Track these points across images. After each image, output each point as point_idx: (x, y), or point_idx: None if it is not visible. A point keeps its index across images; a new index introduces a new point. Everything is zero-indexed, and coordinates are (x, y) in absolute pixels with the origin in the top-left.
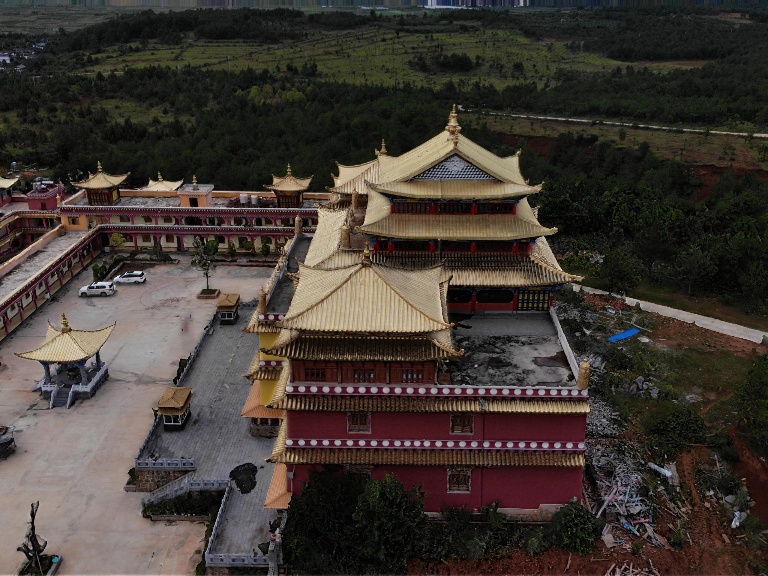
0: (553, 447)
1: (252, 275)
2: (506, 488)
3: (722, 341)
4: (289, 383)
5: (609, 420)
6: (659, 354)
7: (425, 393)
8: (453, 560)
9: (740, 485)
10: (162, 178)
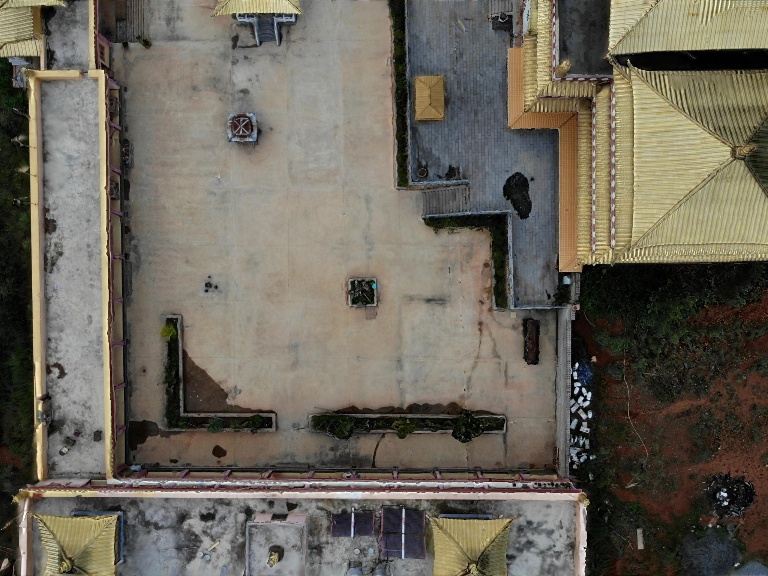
0: None
1: None
2: None
3: None
4: None
5: None
6: None
7: None
8: (713, 305)
9: None
10: None
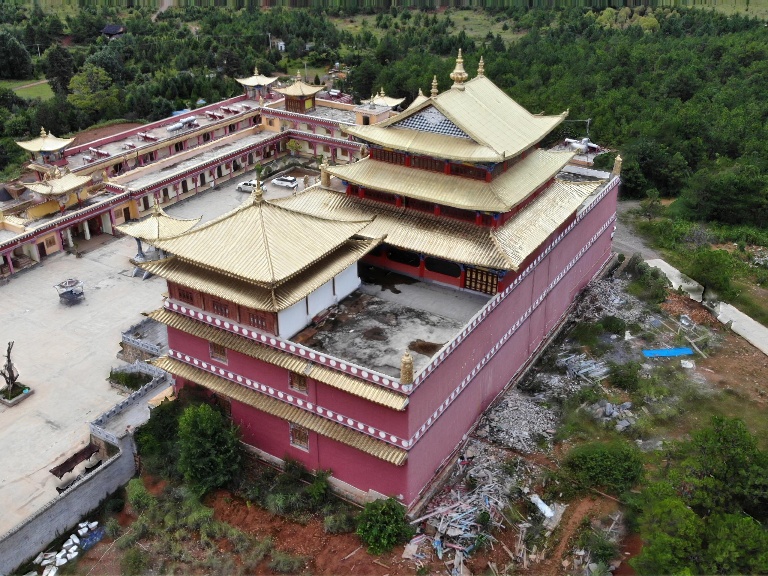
0: (378, 435)
1: None
2: (339, 460)
3: None
4: (168, 298)
5: (534, 435)
6: (685, 385)
7: (266, 341)
8: (256, 506)
9: (612, 557)
10: (384, 93)
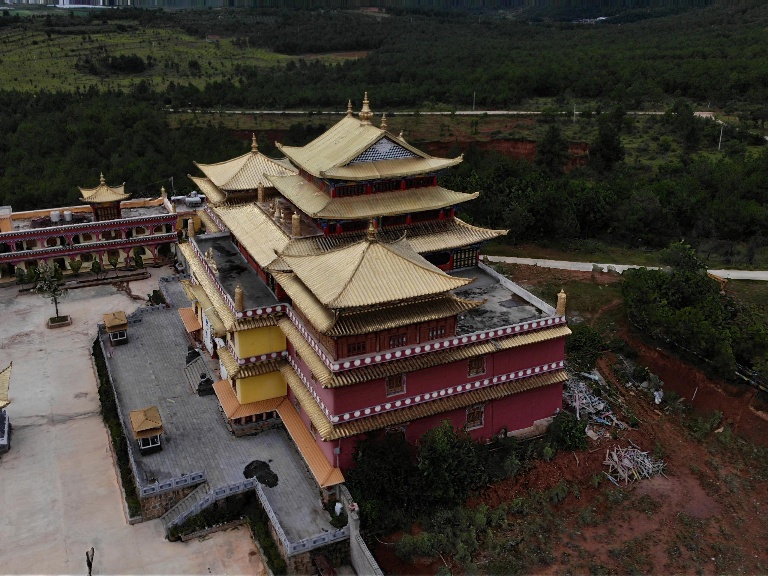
0: (543, 370)
1: (92, 295)
2: (510, 414)
3: (566, 274)
4: (334, 362)
5: None
6: None
7: (449, 345)
8: (496, 483)
9: (648, 372)
10: None
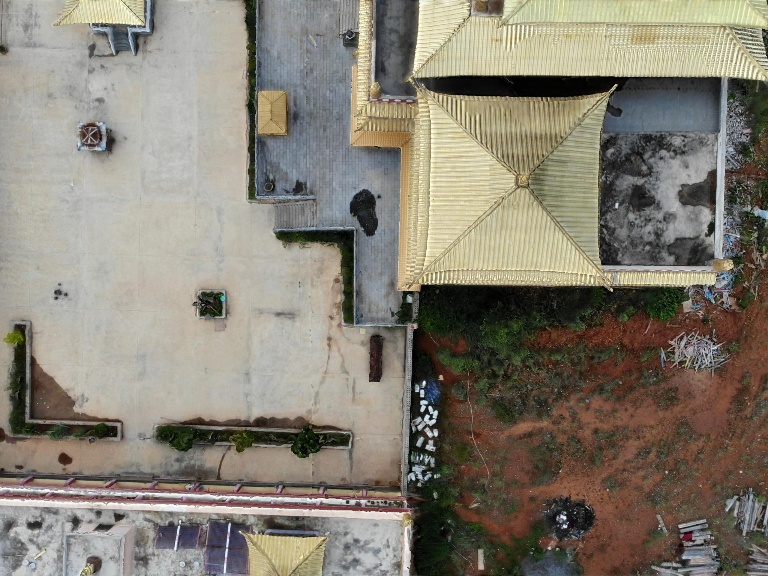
0: None
1: None
2: None
3: None
4: None
5: (737, 146)
6: None
7: None
8: (555, 328)
9: None
10: None
